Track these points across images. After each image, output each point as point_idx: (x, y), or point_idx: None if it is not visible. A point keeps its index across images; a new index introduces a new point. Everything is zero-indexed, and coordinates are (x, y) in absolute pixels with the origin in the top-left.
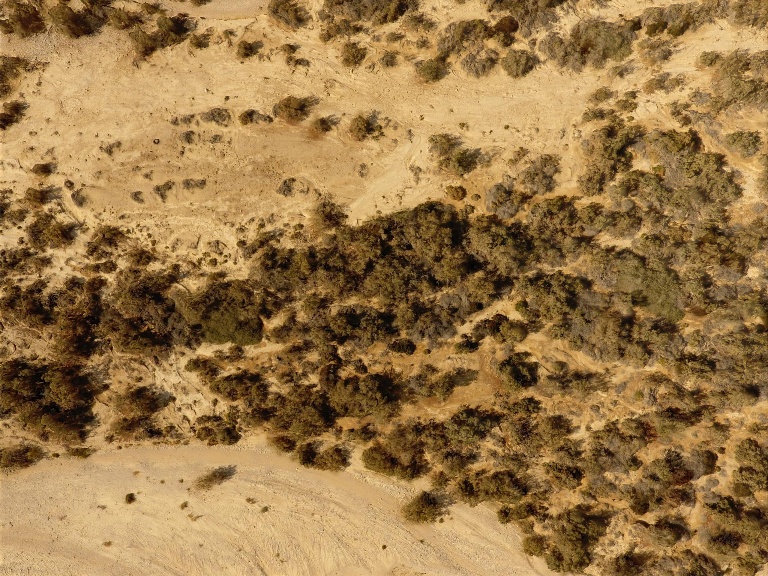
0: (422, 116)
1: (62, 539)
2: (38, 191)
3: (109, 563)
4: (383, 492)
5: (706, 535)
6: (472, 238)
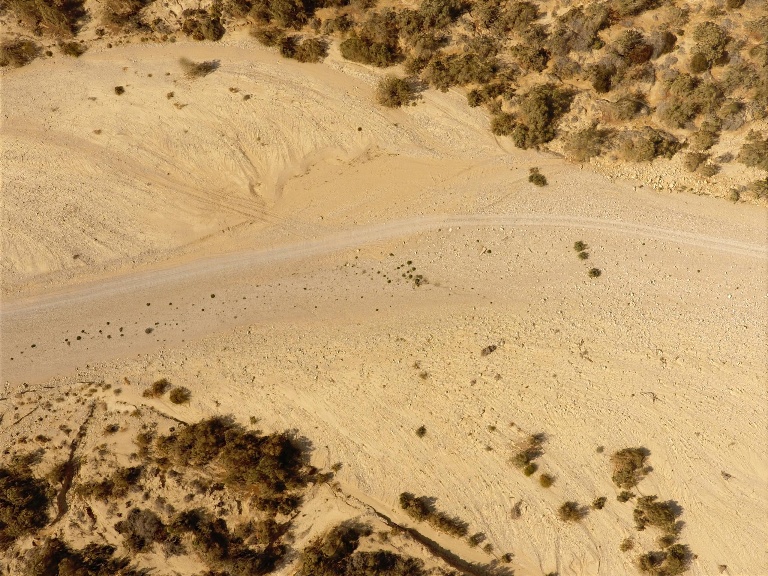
0: None
1: (54, 128)
2: None
3: (99, 149)
4: (359, 81)
5: (664, 106)
6: None
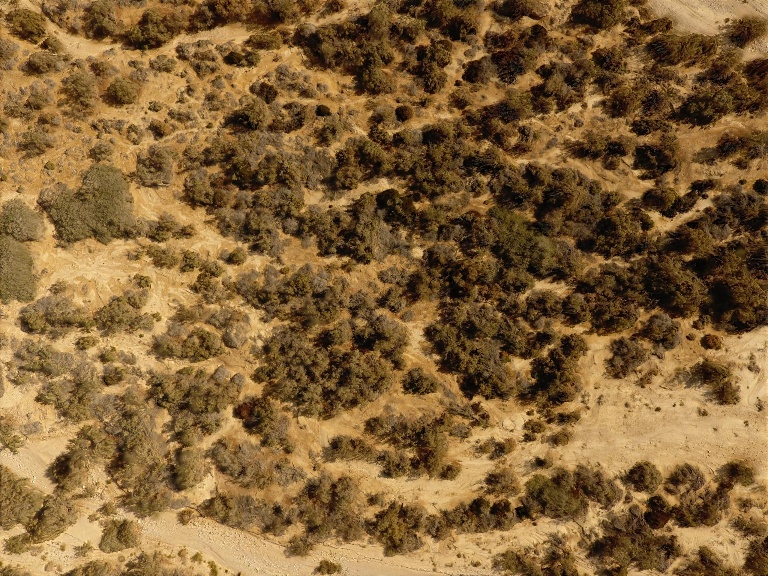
0: (747, 425)
1: None
2: None
3: None
4: None
5: (481, 5)
6: (698, 295)
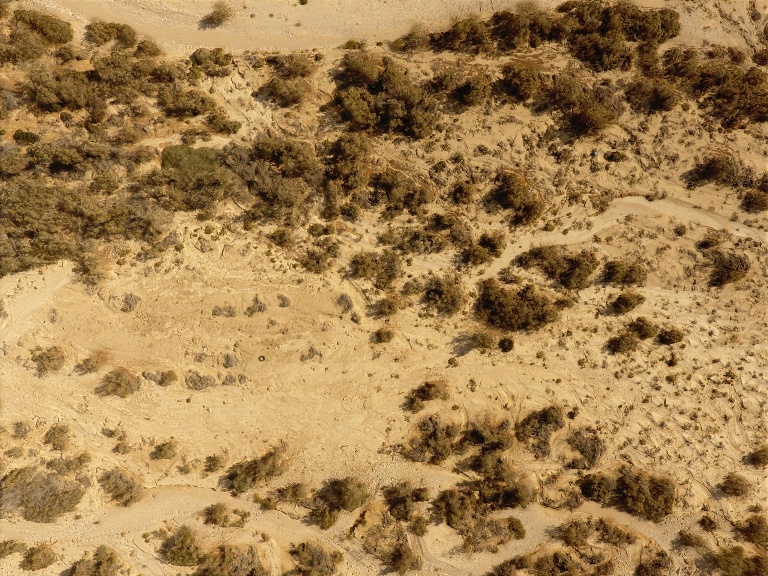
0: None
1: None
2: None
3: None
4: (57, 1)
5: None
6: None
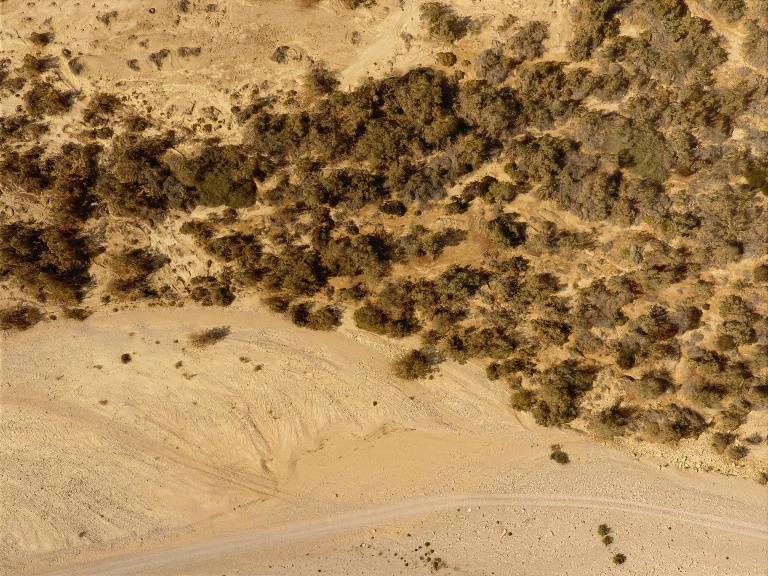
0: None
1: (59, 398)
2: (36, 58)
3: (105, 421)
4: (374, 351)
5: (691, 387)
6: (462, 102)
